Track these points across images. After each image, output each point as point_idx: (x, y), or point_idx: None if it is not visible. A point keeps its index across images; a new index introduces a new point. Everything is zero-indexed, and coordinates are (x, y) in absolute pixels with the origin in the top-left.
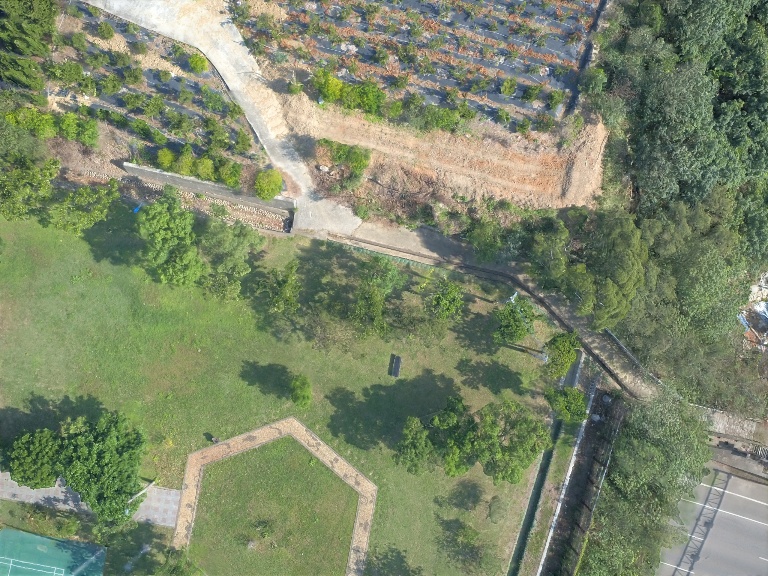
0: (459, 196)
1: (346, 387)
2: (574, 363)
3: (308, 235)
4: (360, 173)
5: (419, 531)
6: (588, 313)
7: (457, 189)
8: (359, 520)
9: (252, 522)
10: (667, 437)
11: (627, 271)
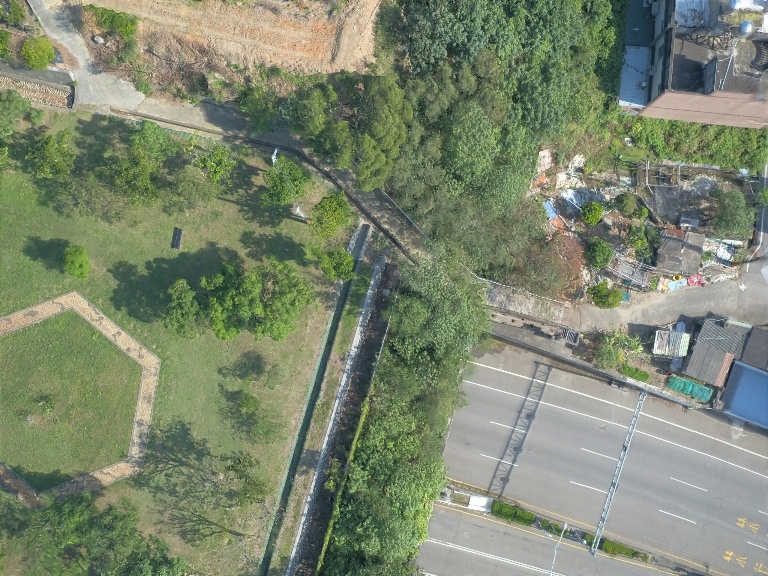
0: (232, 64)
1: (129, 261)
2: (363, 237)
3: (90, 110)
4: (129, 40)
5: (203, 403)
6: (376, 188)
7: (229, 56)
8: (143, 393)
9: (34, 397)
10: (429, 292)
11: (382, 125)
